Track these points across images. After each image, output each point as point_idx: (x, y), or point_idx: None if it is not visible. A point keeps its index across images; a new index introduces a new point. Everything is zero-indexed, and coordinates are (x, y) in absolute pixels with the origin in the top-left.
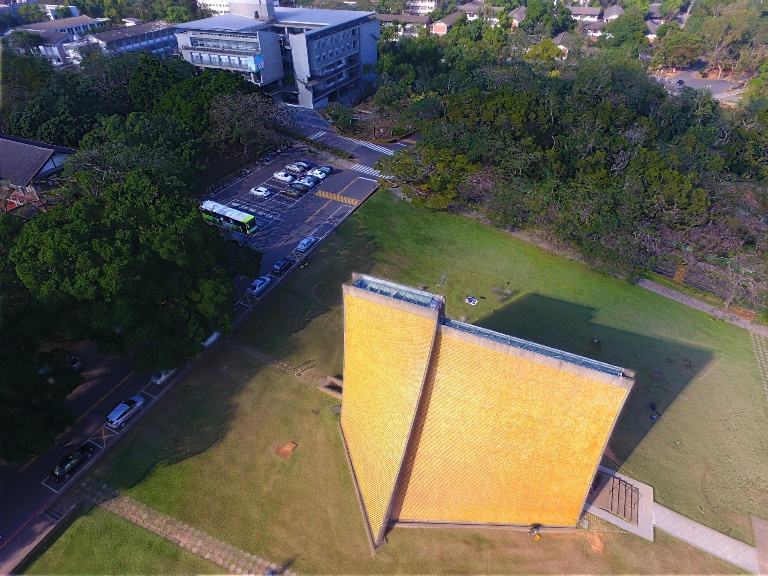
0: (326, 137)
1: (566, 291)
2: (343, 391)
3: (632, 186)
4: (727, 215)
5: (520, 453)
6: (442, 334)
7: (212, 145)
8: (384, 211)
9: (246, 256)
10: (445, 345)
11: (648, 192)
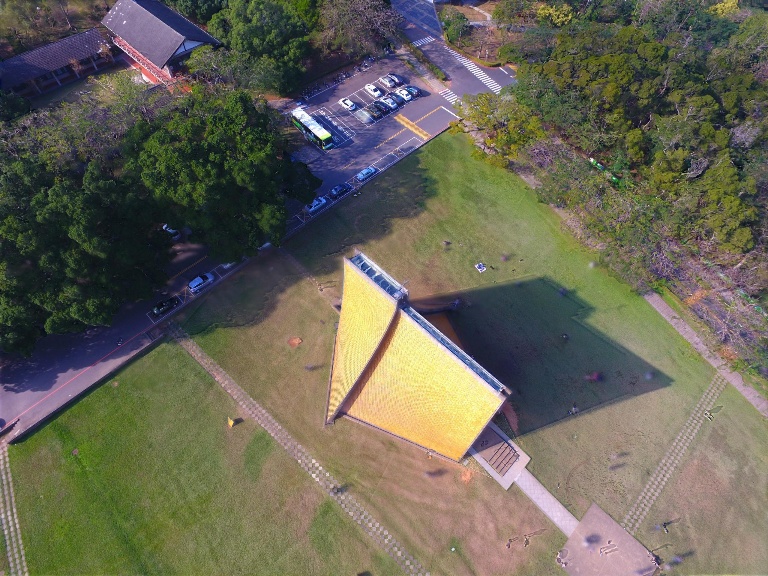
0: (431, 46)
1: (570, 283)
2: (340, 318)
3: (684, 203)
4: (763, 262)
5: (433, 406)
6: (401, 314)
7: (316, 46)
8: (448, 153)
9: (309, 181)
10: (402, 322)
11: (700, 213)
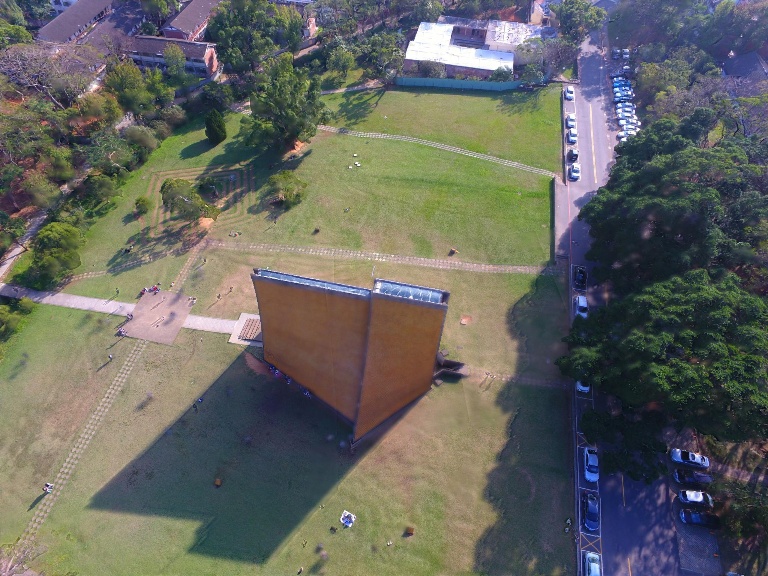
0: None
1: None
2: None
3: None
4: None
5: None
6: None
7: None
8: None
9: None
10: None
11: None
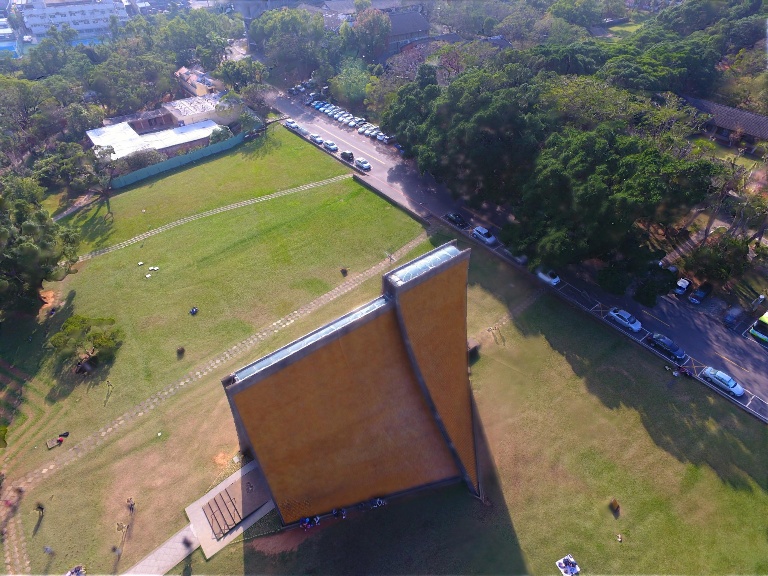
0: None
1: None
2: None
3: None
4: None
5: None
6: None
7: None
8: None
9: None
10: None
11: None
